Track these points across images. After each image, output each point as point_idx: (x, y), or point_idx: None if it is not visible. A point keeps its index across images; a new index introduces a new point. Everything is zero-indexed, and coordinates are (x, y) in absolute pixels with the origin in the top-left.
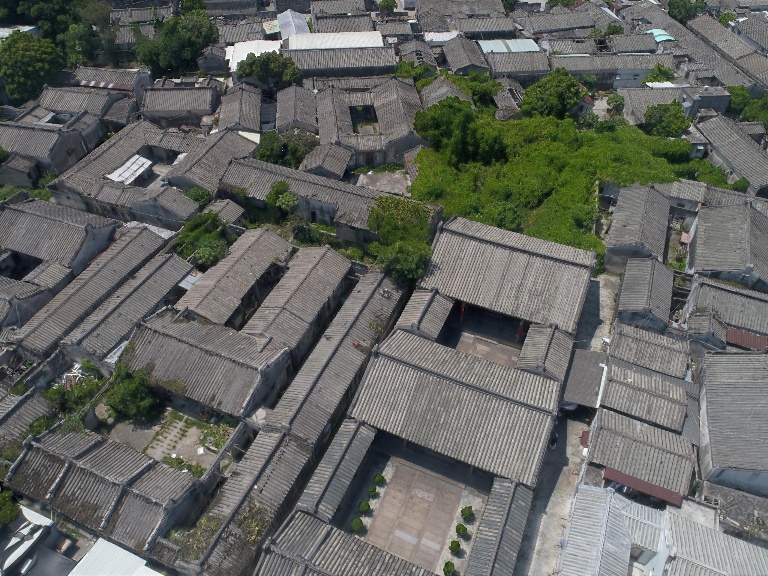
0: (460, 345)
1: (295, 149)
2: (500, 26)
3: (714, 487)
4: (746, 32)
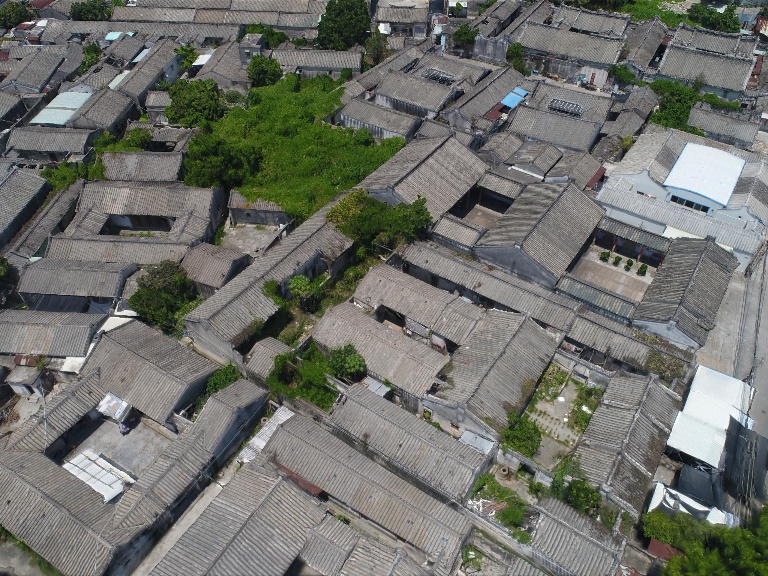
0: None
1: (182, 280)
2: (6, 104)
3: None
4: (153, 5)
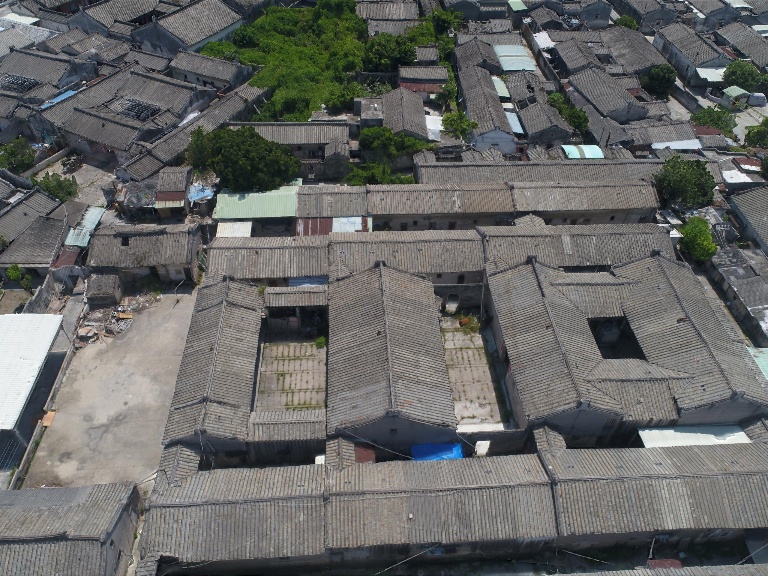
0: None
1: None
2: (572, 61)
3: None
4: None
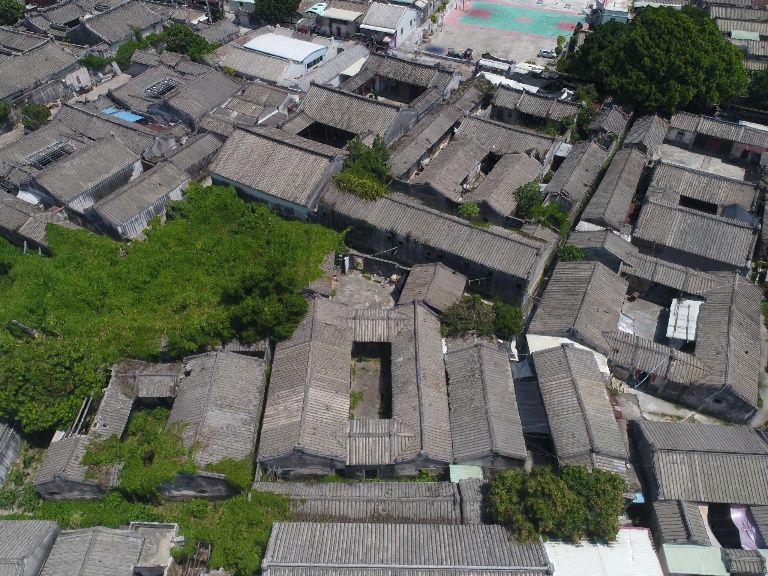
0: None
1: None
2: None
3: (245, 89)
4: None
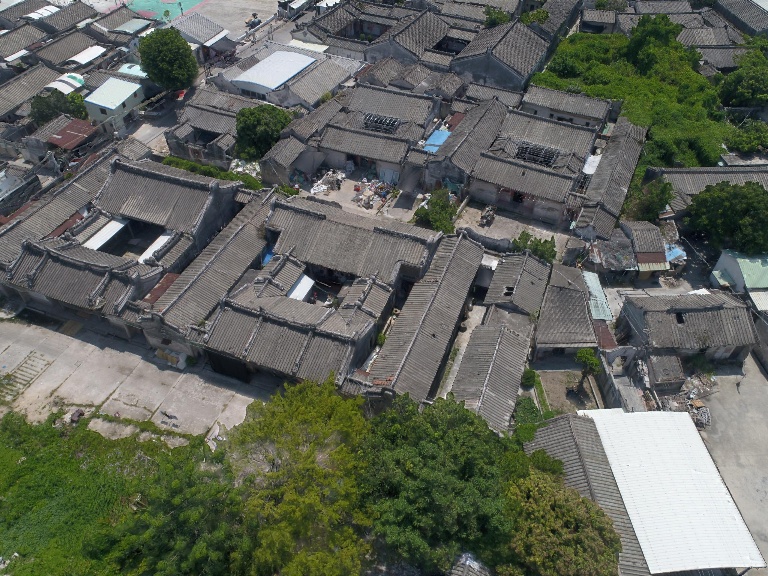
0: None
1: (603, 4)
2: None
3: None
4: None
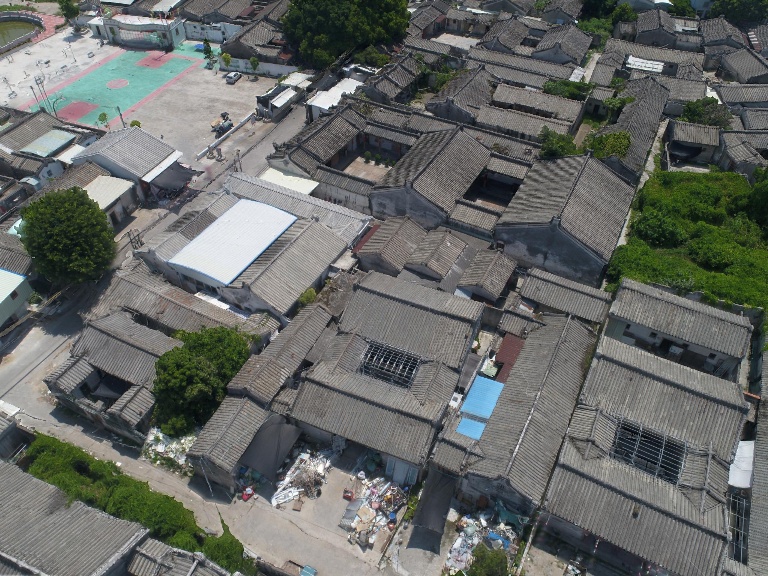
0: (504, 208)
1: (699, 113)
2: None
3: (363, 276)
4: None
